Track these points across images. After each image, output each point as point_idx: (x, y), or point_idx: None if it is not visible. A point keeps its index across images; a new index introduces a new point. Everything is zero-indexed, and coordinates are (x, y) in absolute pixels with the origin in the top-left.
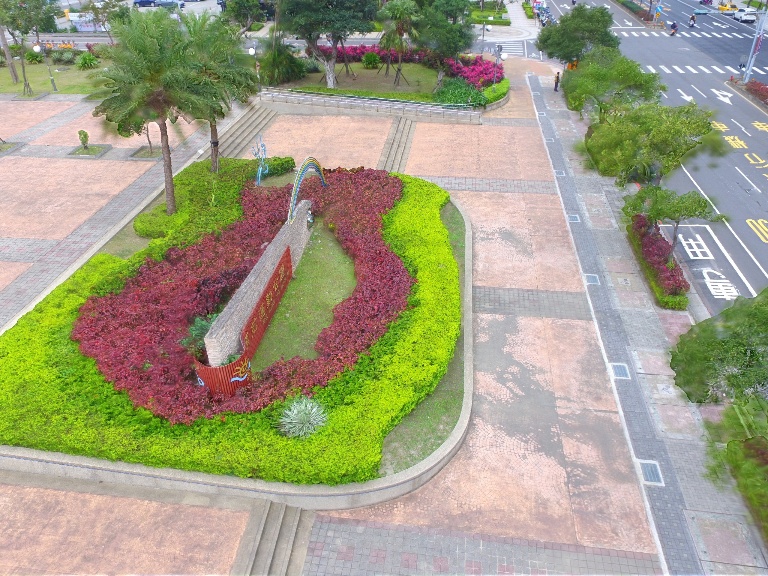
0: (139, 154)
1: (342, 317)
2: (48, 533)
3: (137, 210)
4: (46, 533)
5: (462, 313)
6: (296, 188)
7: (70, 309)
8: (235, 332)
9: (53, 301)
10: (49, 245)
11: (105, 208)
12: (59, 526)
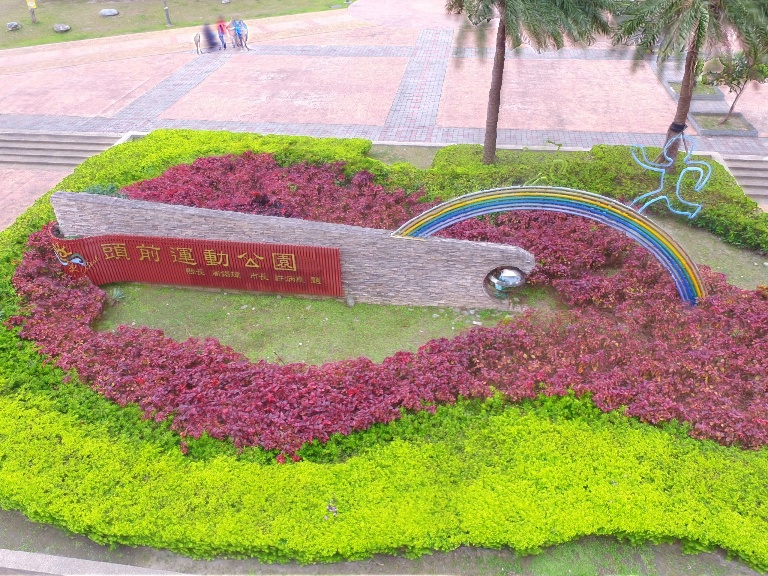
0: (712, 117)
1: (180, 347)
2: (1, 222)
3: (513, 146)
4: (1, 221)
5: (196, 569)
6: (470, 205)
7: (255, 149)
8: (111, 228)
9: (273, 138)
10: (422, 123)
11: (523, 131)
12: (4, 224)
